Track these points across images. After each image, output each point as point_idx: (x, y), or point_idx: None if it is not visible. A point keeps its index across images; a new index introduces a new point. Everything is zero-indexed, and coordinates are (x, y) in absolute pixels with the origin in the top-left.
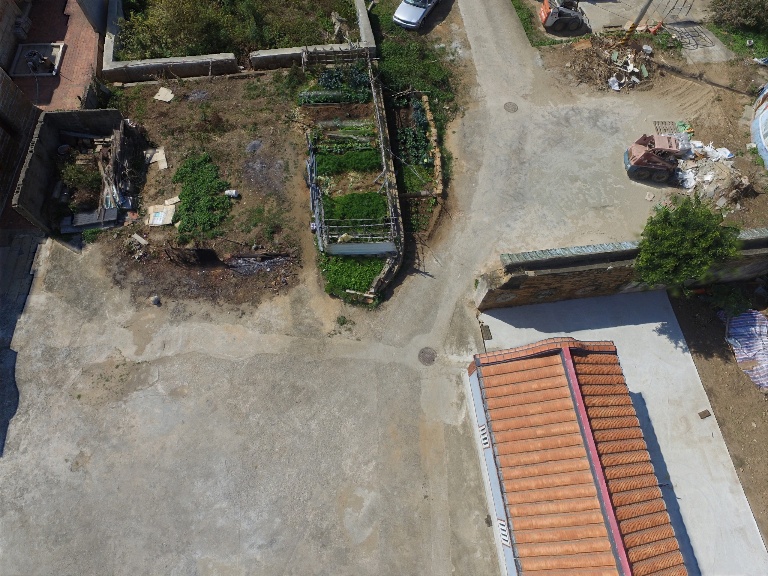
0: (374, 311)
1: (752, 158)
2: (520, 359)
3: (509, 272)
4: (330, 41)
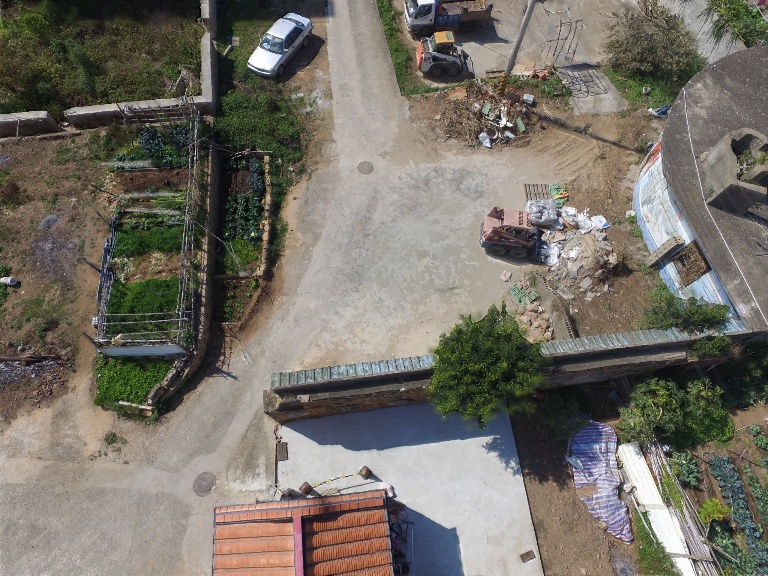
0: (153, 425)
1: (630, 228)
2: (257, 521)
3: (280, 396)
4: (167, 93)
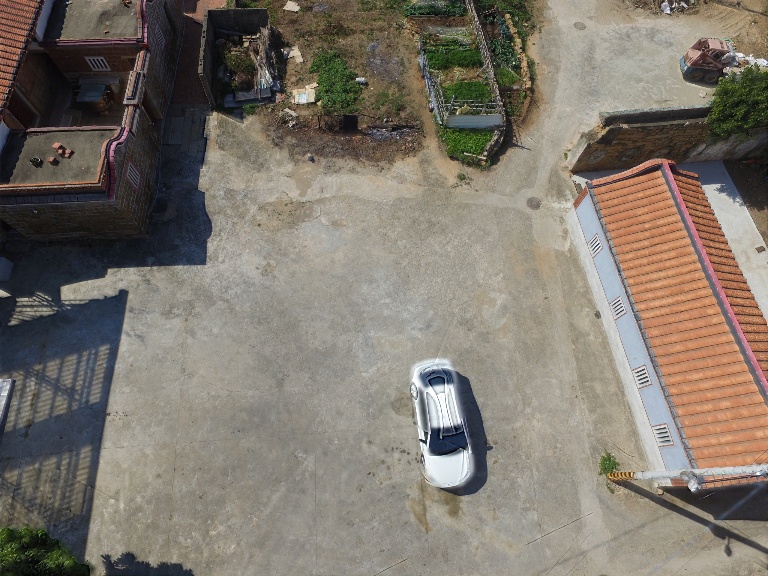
0: (486, 171)
1: None
2: (626, 179)
3: (607, 126)
4: None
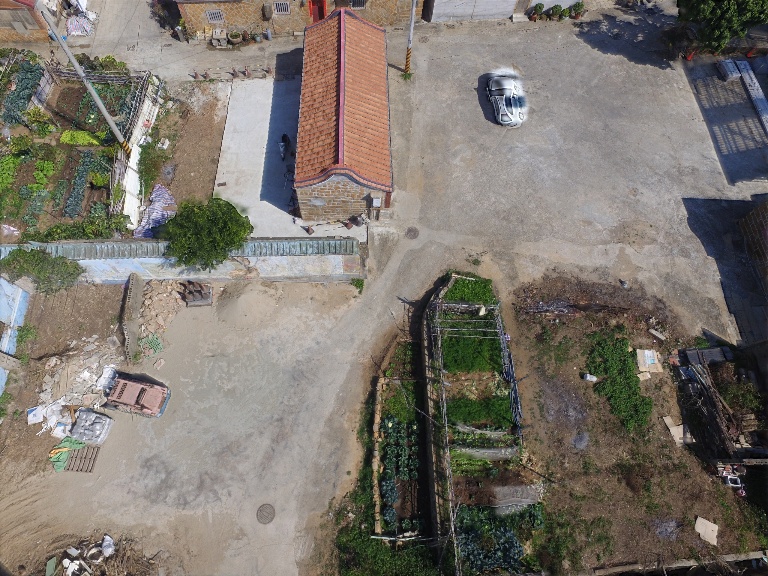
0: None
1: (8, 405)
2: None
3: None
4: None
